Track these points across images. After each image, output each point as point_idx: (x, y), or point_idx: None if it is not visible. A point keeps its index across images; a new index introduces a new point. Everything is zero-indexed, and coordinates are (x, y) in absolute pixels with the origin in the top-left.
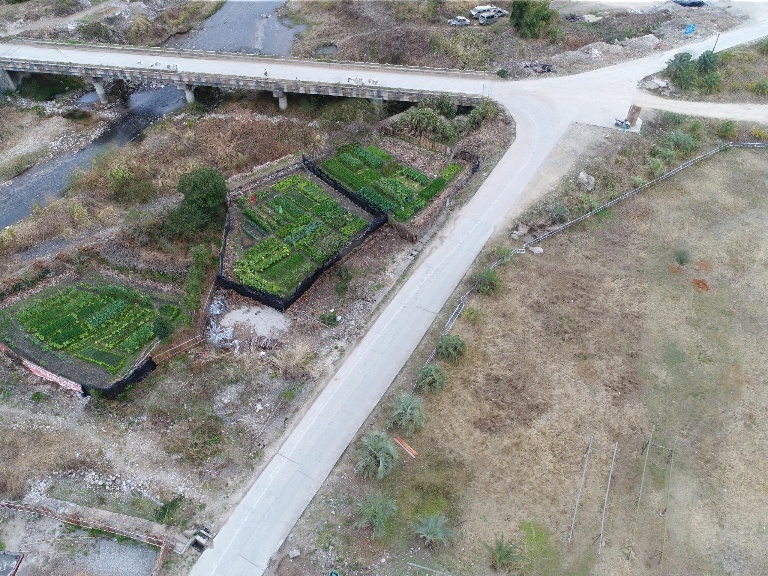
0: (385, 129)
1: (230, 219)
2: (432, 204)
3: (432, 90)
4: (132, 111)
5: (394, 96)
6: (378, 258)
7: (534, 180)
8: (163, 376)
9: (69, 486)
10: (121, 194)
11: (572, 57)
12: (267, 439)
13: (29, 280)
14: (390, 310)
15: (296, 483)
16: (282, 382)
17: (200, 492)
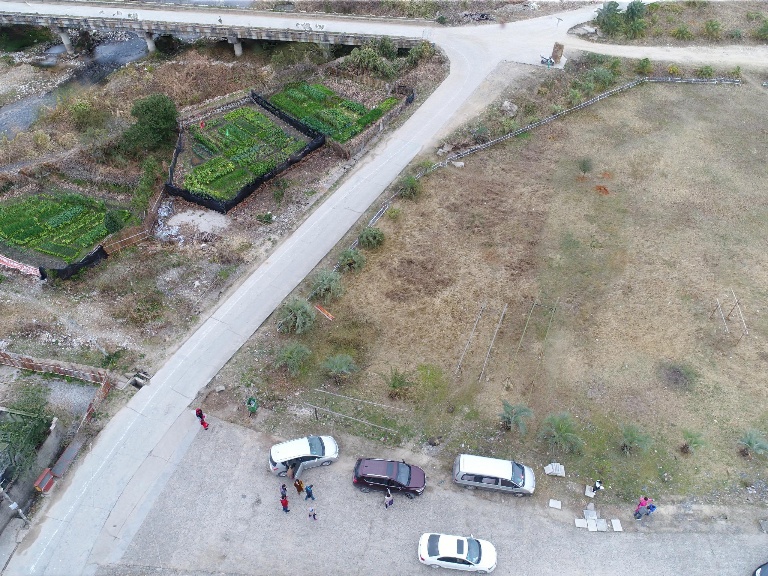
0: (331, 69)
1: (182, 143)
2: (368, 129)
3: (375, 34)
4: (97, 60)
5: (340, 40)
6: (314, 172)
7: (462, 108)
8: (113, 263)
9: (26, 343)
10: (83, 125)
11: (512, 9)
12: (202, 307)
13: None
14: (321, 211)
15: (225, 338)
16: (219, 265)
17: (141, 346)
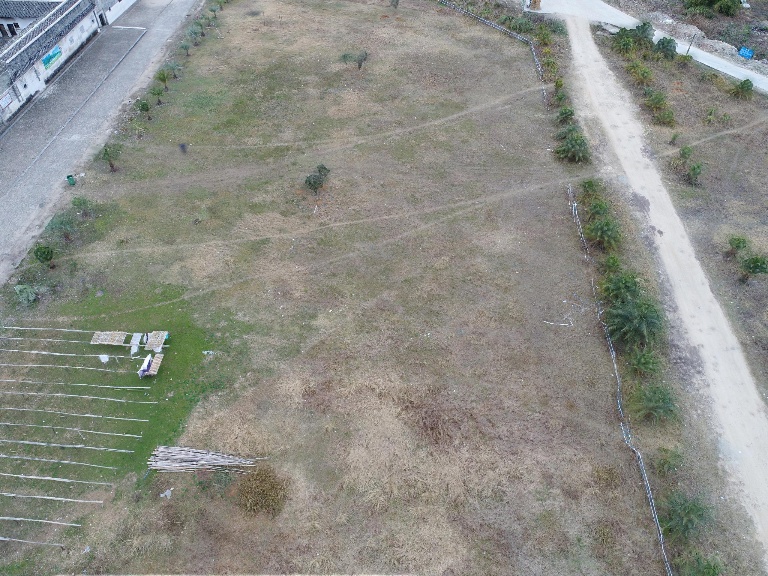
0: None
1: None
2: None
3: None
4: None
5: None
6: None
7: None
8: None
9: None
10: None
11: None
12: None
13: None
14: None
15: None
16: None
17: None
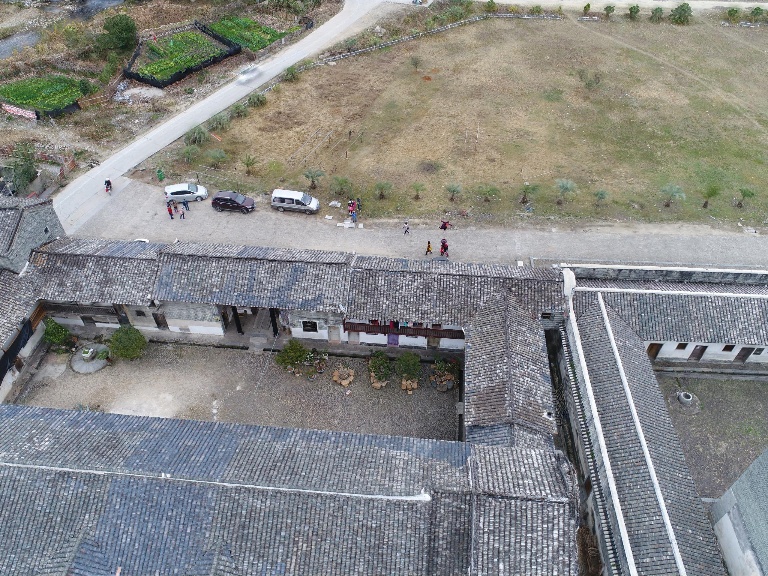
0: (258, 8)
1: (140, 51)
2: None
3: None
4: (87, 6)
5: None
6: (230, 67)
7: (345, 31)
8: None
9: None
10: None
11: None
12: (138, 133)
13: (7, 74)
14: (227, 87)
15: None
16: None
17: (97, 149)
